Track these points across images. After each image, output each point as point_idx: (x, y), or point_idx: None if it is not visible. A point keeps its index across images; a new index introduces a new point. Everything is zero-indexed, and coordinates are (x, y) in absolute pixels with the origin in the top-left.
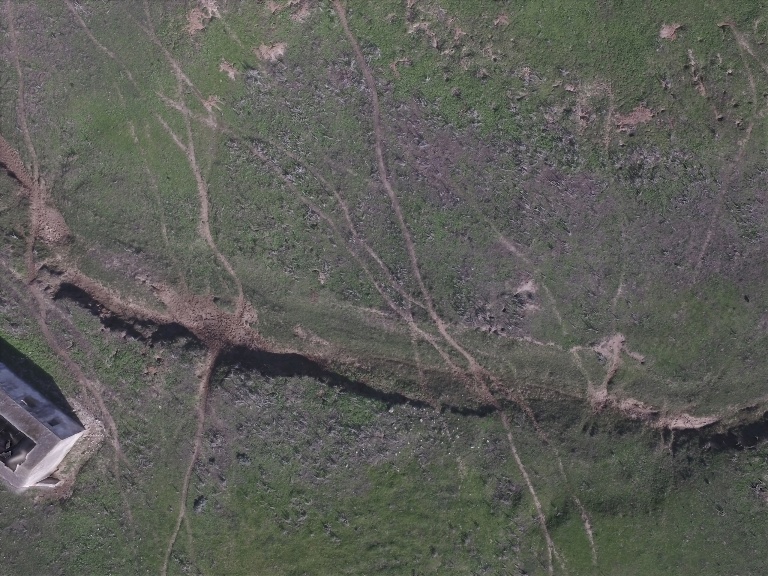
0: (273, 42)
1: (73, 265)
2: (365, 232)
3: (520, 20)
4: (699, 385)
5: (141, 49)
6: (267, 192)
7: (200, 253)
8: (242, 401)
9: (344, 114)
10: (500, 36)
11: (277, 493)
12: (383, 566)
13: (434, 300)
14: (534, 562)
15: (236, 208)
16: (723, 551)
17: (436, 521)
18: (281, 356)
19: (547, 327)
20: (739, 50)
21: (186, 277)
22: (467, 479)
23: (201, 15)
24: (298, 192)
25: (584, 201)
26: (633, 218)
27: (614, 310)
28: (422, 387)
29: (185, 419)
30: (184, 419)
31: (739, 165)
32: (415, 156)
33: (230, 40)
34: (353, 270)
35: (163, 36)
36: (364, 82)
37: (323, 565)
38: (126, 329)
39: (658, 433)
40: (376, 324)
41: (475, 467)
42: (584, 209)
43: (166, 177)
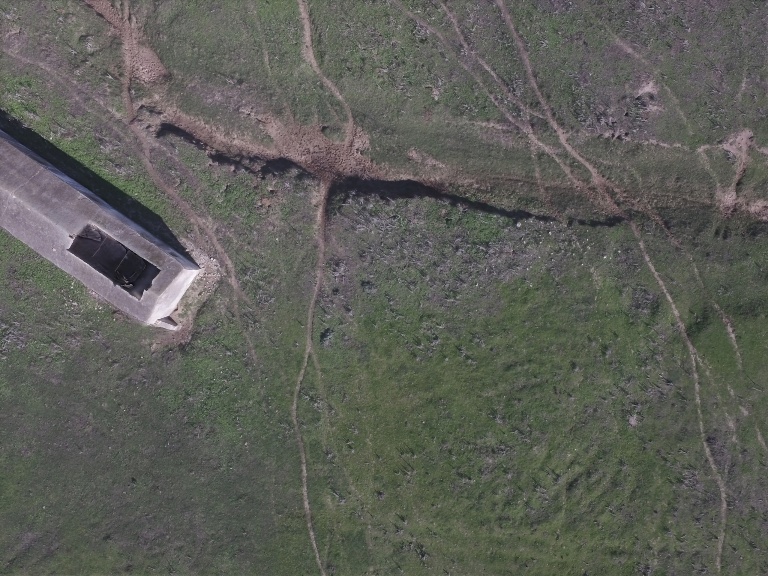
0: None
1: (172, 104)
2: (477, 44)
3: None
4: None
5: None
6: (372, 9)
7: (305, 79)
8: (363, 226)
9: None
10: None
11: (406, 319)
12: (522, 386)
13: (553, 109)
14: (678, 370)
15: (341, 27)
16: None
17: (574, 335)
18: (396, 183)
19: (672, 128)
20: None
21: (292, 107)
22: (603, 289)
23: None
24: (404, 8)
25: None
26: (752, 10)
27: (740, 106)
28: (545, 203)
29: (304, 250)
30: (303, 250)
31: None
32: None
33: None
34: (467, 84)
35: None
36: None
37: (460, 390)
38: (234, 164)
39: None
40: (493, 141)
41: (609, 277)
42: (701, 5)
43: (265, 1)
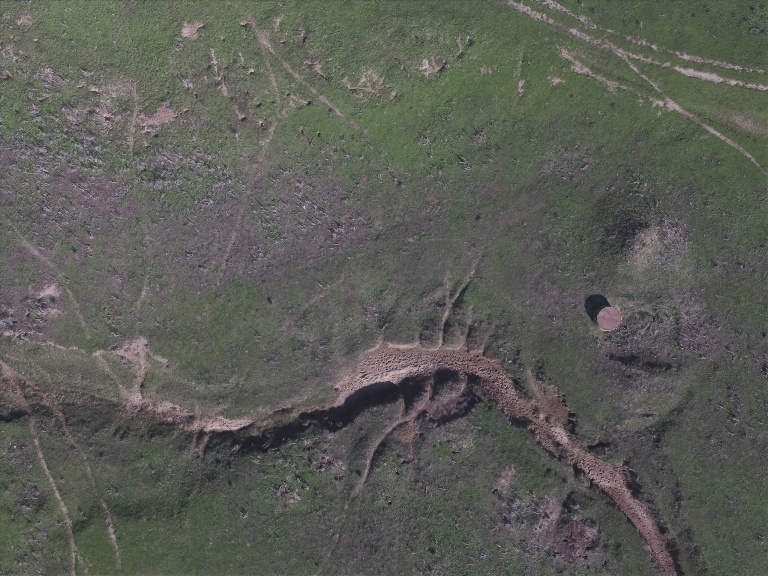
0: None
1: None
2: None
3: (45, 20)
4: (227, 387)
5: None
6: None
7: None
8: None
9: None
10: (22, 36)
11: None
12: None
13: None
14: (56, 567)
15: None
16: (247, 553)
17: None
18: None
19: (70, 331)
20: (261, 49)
21: None
22: None
23: None
24: None
25: (108, 203)
26: (157, 220)
27: (138, 313)
28: None
29: None
30: None
31: (263, 165)
32: None
33: None
34: None
35: None
36: None
37: None
38: None
39: (191, 436)
40: None
41: None
42: (108, 211)
43: None
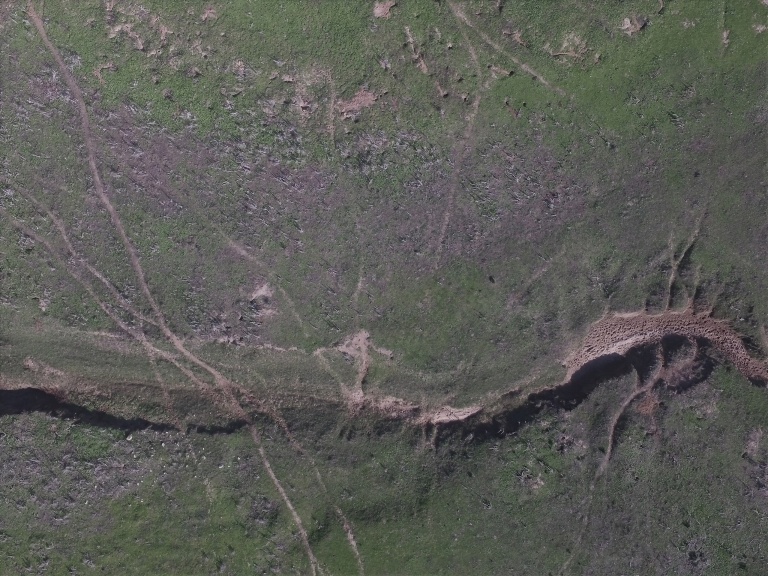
0: None
1: None
2: (85, 252)
3: (229, 13)
4: (454, 374)
5: None
6: None
7: None
8: None
9: (52, 129)
10: (208, 32)
11: (15, 540)
12: None
13: (165, 316)
14: None
15: None
16: (495, 546)
17: (187, 550)
18: (15, 392)
19: (287, 331)
20: (457, 23)
21: None
22: (216, 502)
23: None
24: (9, 217)
25: (314, 195)
26: (366, 208)
27: (356, 306)
28: (167, 409)
29: None
30: None
31: (470, 141)
32: (131, 166)
33: None
34: (76, 293)
35: None
36: (69, 93)
37: None
38: None
39: (419, 429)
40: (110, 347)
41: (225, 488)
42: (314, 203)
43: None
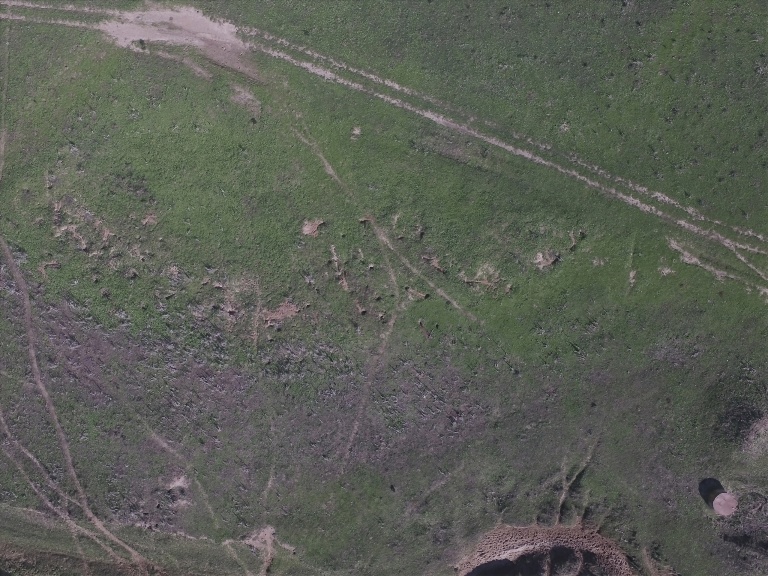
0: None
1: None
2: (19, 434)
3: (169, 219)
4: (352, 572)
5: None
6: None
7: None
8: None
9: None
10: (148, 236)
11: None
12: None
13: (89, 498)
14: None
15: None
16: None
17: None
18: None
19: (200, 522)
20: (380, 245)
21: None
22: None
23: None
24: None
25: (234, 396)
26: (281, 412)
27: (265, 503)
28: None
29: None
30: None
31: (383, 357)
32: (67, 357)
33: None
34: (9, 471)
35: None
36: (14, 286)
37: None
38: None
39: None
40: (37, 521)
41: None
42: (234, 404)
43: None
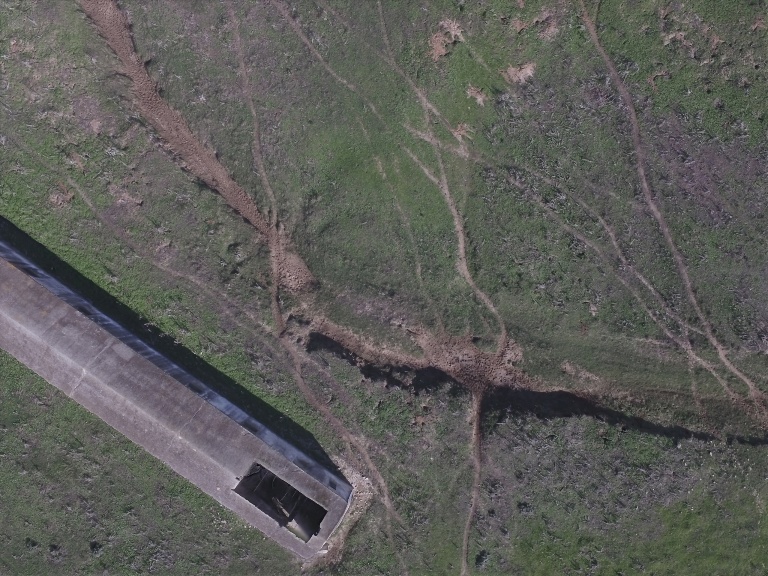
0: (521, 64)
1: (320, 313)
2: (635, 258)
3: None
4: None
5: (383, 80)
6: (528, 222)
7: (458, 292)
8: (520, 447)
9: (601, 135)
10: (760, 42)
11: (564, 542)
12: None
13: (713, 325)
14: None
15: (498, 242)
16: None
17: (737, 560)
18: (548, 395)
19: None
20: None
21: (443, 318)
22: (766, 513)
23: (444, 40)
24: (560, 220)
25: None
26: None
27: None
28: (702, 418)
29: (459, 470)
30: (458, 470)
31: None
32: (681, 174)
33: (476, 64)
34: (625, 299)
35: (405, 65)
36: (621, 100)
37: None
38: (385, 378)
39: None
40: (650, 354)
41: None
42: None
43: (419, 214)
